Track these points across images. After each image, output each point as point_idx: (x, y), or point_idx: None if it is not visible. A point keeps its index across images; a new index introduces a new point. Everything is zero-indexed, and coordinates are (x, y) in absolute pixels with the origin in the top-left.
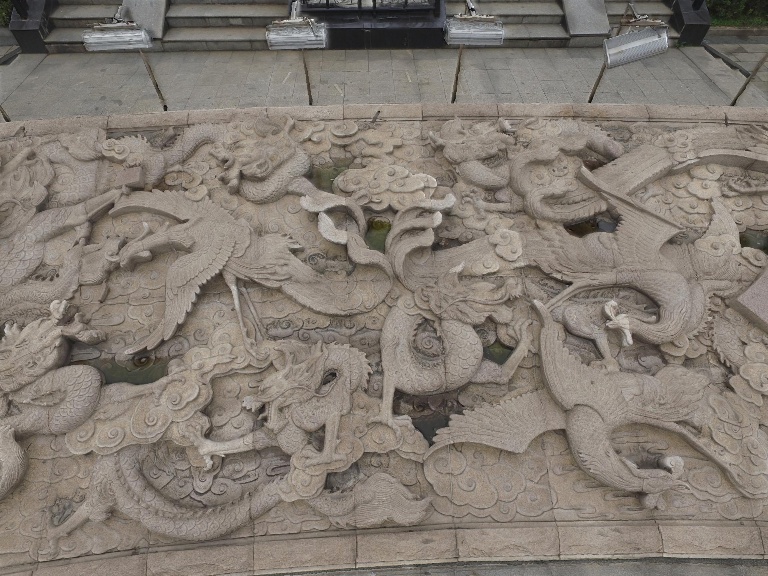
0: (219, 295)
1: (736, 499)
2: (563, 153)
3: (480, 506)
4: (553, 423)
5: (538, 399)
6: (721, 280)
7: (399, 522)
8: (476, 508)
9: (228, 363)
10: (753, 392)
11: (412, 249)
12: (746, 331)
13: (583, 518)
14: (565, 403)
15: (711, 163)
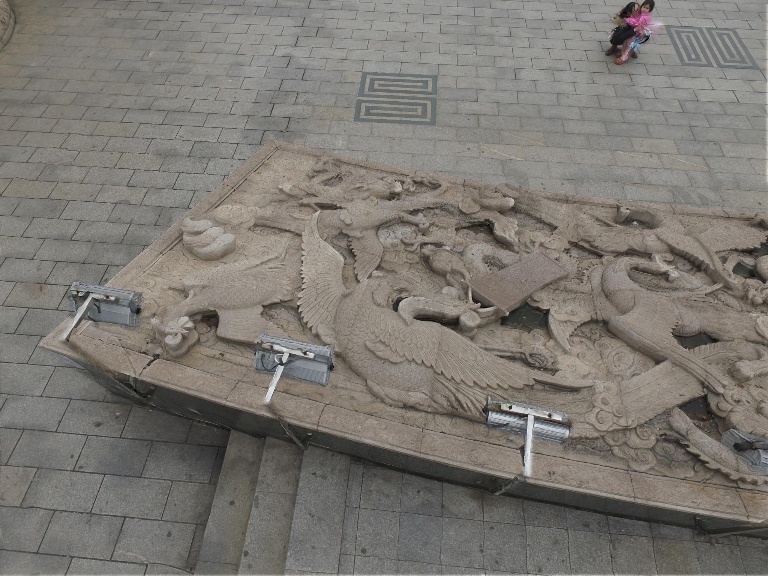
0: None
1: None
2: None
3: None
4: None
5: None
6: (571, 292)
7: None
8: None
9: None
10: None
11: None
12: None
13: None
14: None
15: None
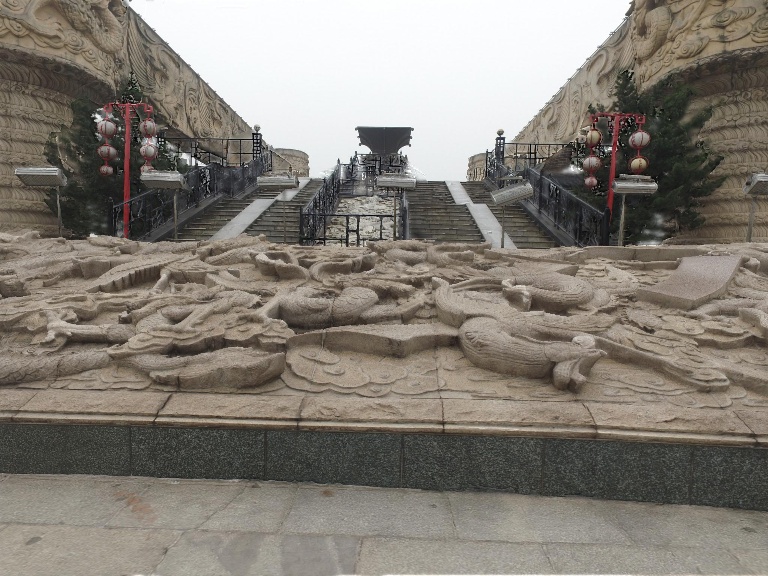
0: (149, 288)
1: (690, 394)
2: (473, 251)
3: (344, 385)
4: (444, 331)
5: (431, 325)
6: None
7: (232, 365)
8: (339, 387)
9: (126, 298)
10: (682, 337)
11: (331, 265)
12: (660, 311)
13: (479, 397)
14: (454, 311)
15: (601, 257)
